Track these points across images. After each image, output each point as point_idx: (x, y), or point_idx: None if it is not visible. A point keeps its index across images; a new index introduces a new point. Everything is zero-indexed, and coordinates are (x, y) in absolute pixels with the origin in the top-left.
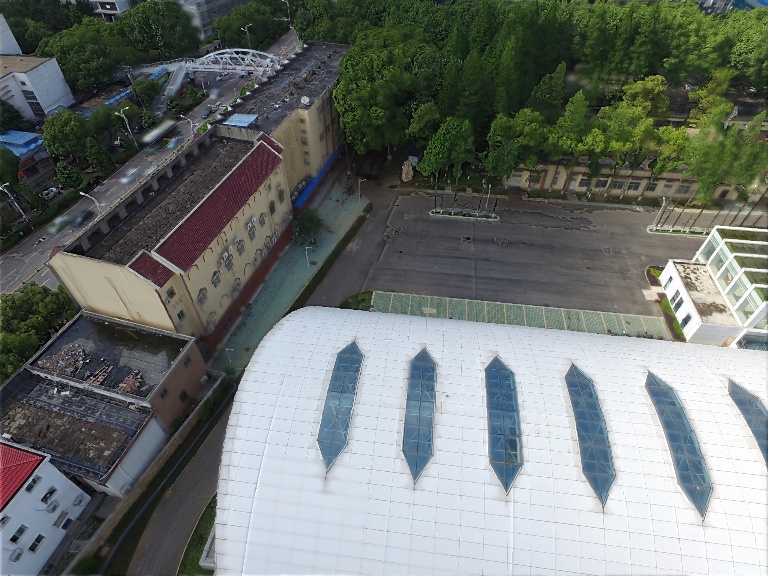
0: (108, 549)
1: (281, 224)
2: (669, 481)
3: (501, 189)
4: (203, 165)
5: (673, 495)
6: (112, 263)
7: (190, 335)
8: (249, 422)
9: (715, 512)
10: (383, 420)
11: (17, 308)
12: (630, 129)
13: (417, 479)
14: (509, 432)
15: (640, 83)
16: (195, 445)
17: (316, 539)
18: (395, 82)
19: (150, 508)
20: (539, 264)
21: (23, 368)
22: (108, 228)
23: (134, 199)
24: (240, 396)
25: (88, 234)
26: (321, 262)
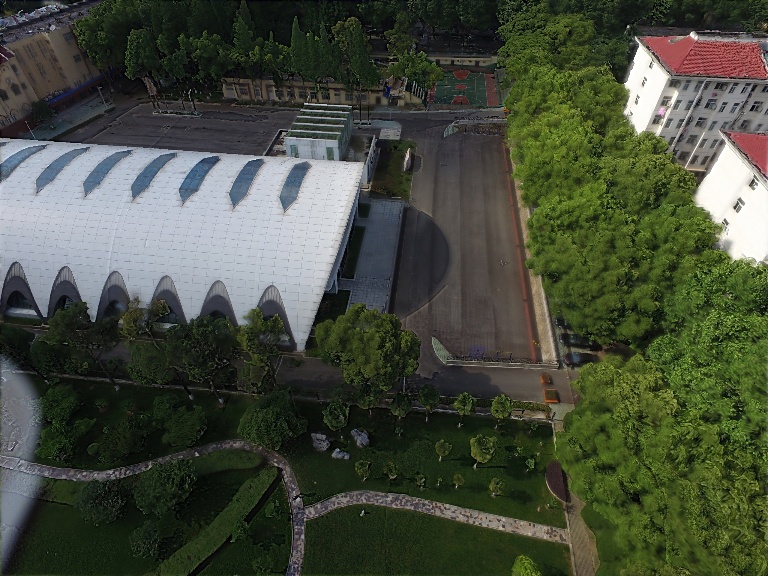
0: None
1: (20, 111)
2: (80, 182)
3: (220, 100)
4: None
5: (77, 187)
6: None
7: None
8: None
9: (94, 193)
10: None
11: None
12: (283, 46)
13: None
14: None
15: (338, 23)
16: None
17: None
18: (121, 15)
19: None
20: (205, 139)
21: None
22: None
23: None
24: None
25: None
26: None
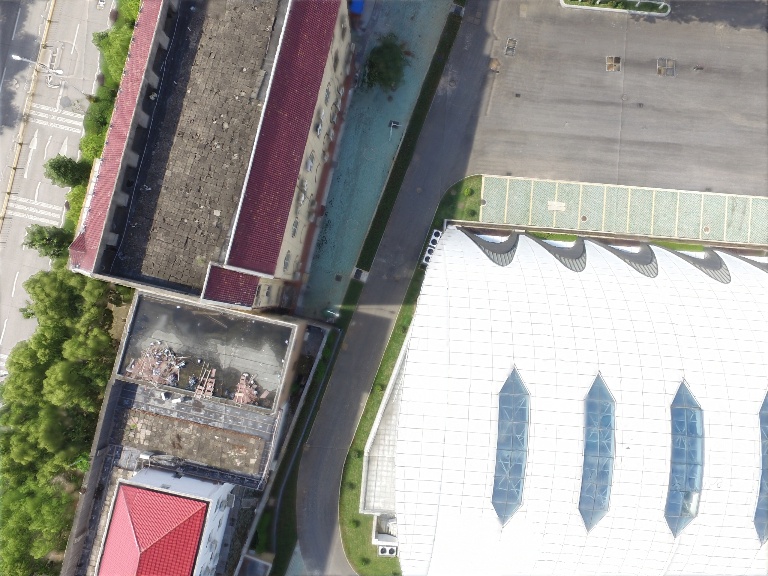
0: (274, 500)
1: (343, 70)
2: None
3: None
4: (210, 3)
5: None
6: (178, 295)
7: (277, 292)
8: (417, 487)
9: None
10: (559, 479)
11: (56, 300)
12: None
13: (591, 531)
14: (689, 485)
15: None
16: (317, 401)
17: (492, 567)
18: None
19: (296, 463)
20: (713, 112)
21: (114, 379)
22: (126, 196)
23: (136, 126)
24: (401, 460)
25: (108, 226)
26: (404, 122)
